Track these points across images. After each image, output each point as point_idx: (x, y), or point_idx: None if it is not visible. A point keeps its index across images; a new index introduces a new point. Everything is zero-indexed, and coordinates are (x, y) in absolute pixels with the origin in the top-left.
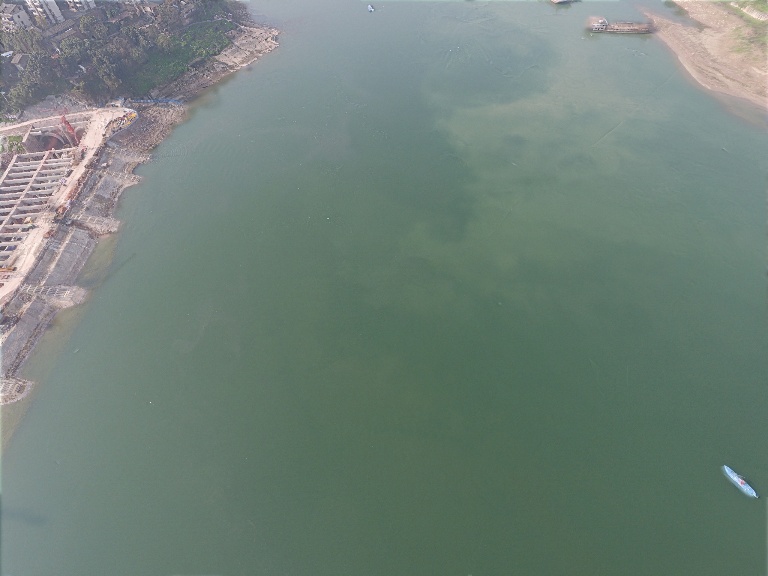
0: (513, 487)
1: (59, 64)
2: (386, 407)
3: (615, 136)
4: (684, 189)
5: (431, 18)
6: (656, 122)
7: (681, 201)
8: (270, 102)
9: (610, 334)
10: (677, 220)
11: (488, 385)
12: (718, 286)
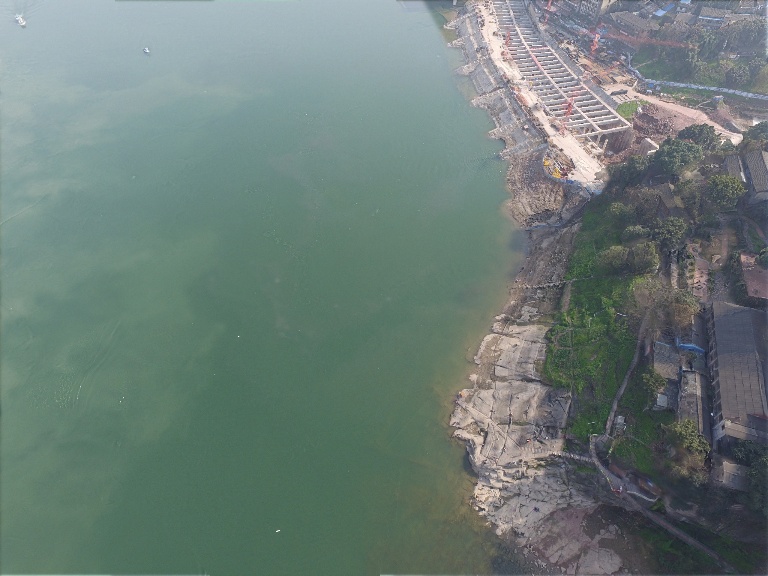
0: (231, 43)
1: None
2: (276, 55)
3: (3, 217)
4: (14, 162)
5: None
6: None
7: (30, 152)
8: (401, 241)
9: (156, 85)
10: None
11: (228, 66)
12: (74, 107)
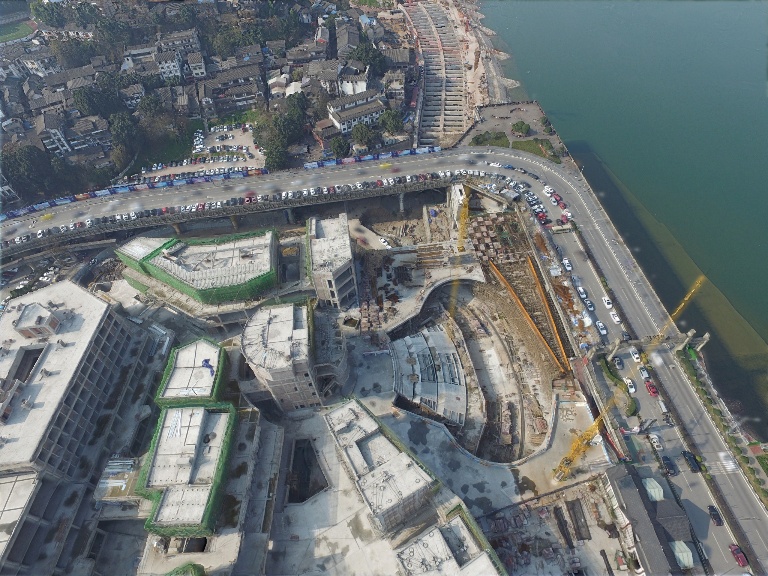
0: None
1: None
2: (724, 79)
3: None
4: None
5: None
6: None
7: None
8: None
9: None
10: None
11: None
12: None
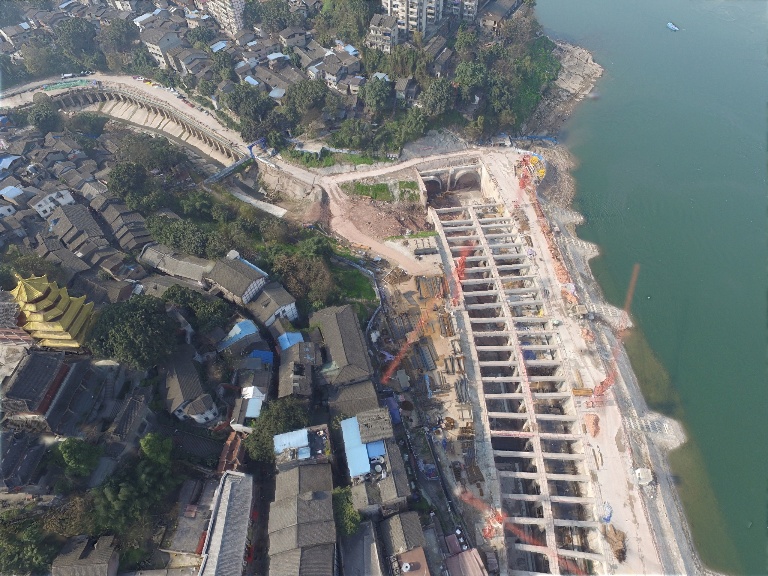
0: None
1: (458, 94)
2: None
3: None
4: None
5: (751, 42)
6: None
7: None
8: (664, 145)
9: None
10: None
11: None
12: None
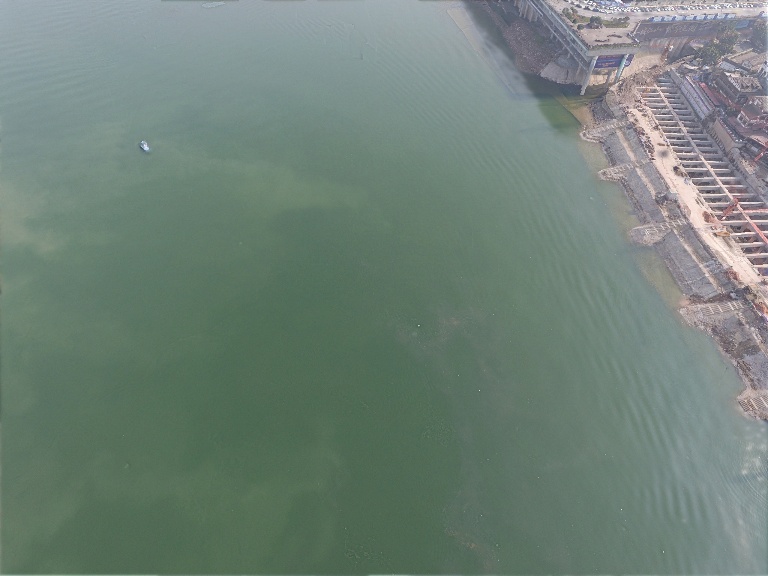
0: (272, 142)
1: None
2: (344, 173)
3: None
4: None
5: None
6: None
7: None
8: None
9: (160, 221)
10: None
11: (271, 188)
12: (26, 261)
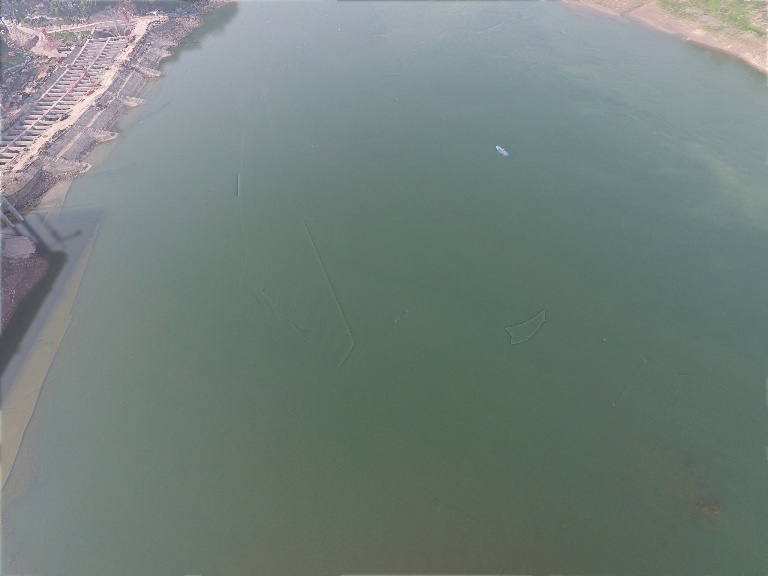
0: None
1: None
2: (322, 135)
3: (495, 29)
4: (528, 51)
5: None
6: (525, 21)
7: (523, 56)
8: (261, 15)
9: (458, 109)
10: (518, 65)
11: (382, 128)
12: (529, 89)
